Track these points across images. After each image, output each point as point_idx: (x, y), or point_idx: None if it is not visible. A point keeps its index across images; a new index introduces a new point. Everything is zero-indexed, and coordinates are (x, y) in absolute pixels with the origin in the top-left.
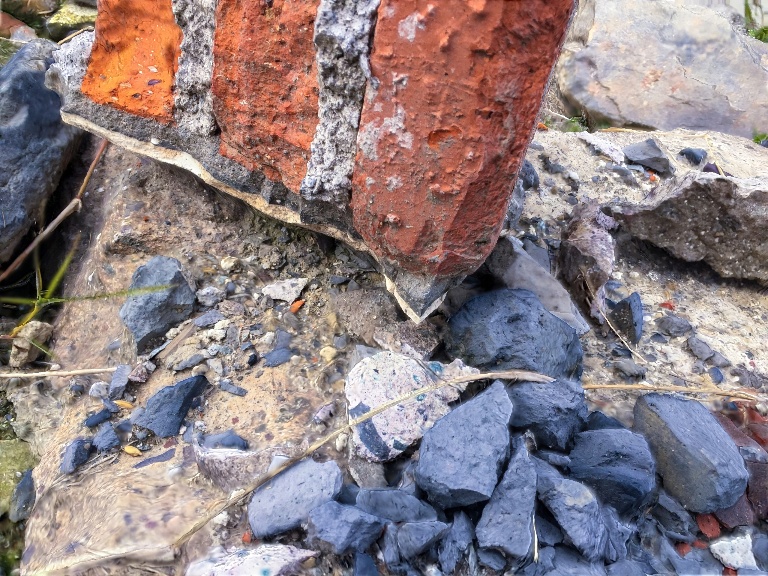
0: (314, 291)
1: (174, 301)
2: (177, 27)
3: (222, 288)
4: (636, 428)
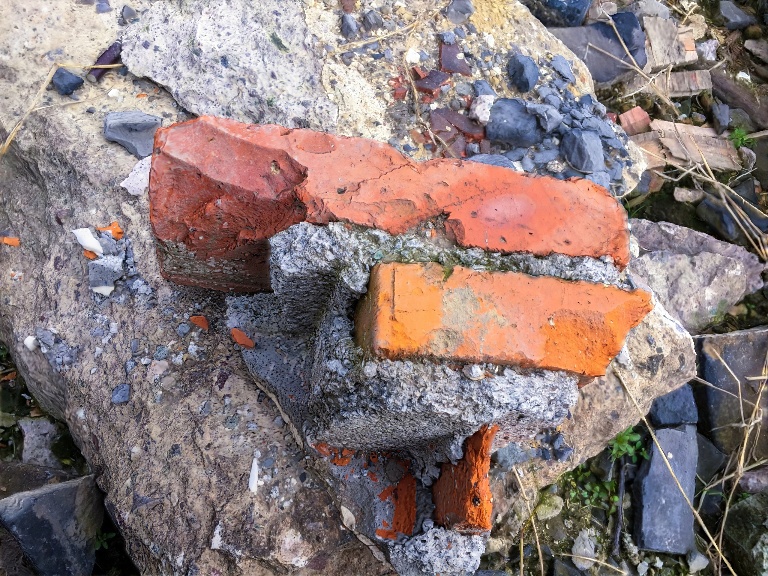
0: None
1: None
2: None
3: None
4: None
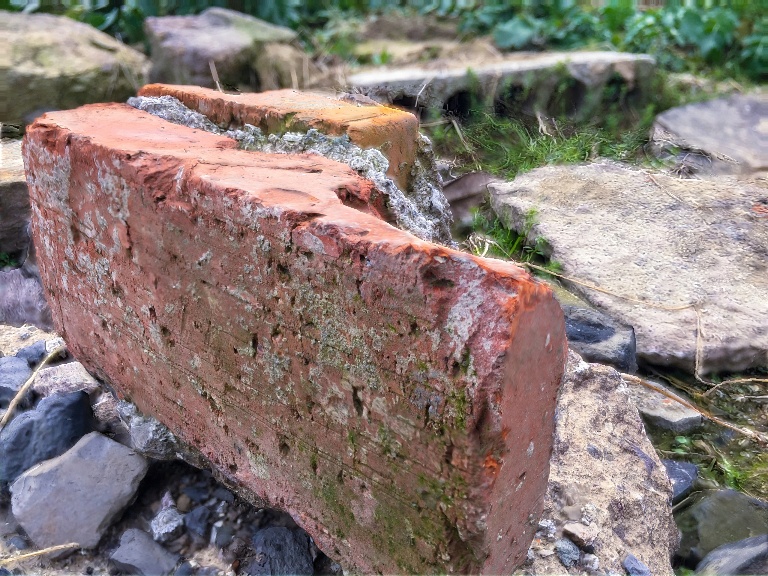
0: None
1: None
2: None
3: None
4: None
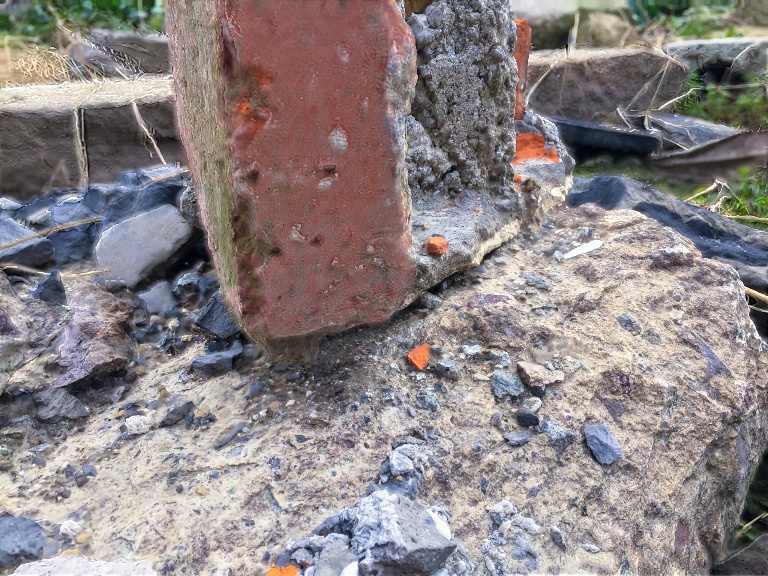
0: None
1: None
2: None
3: None
4: None
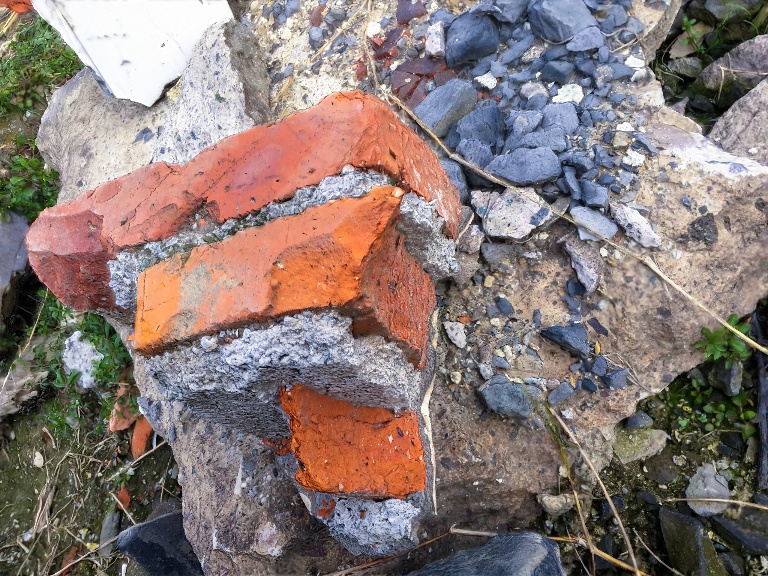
0: (450, 315)
1: (506, 381)
2: (361, 426)
3: (474, 373)
4: (443, 134)
